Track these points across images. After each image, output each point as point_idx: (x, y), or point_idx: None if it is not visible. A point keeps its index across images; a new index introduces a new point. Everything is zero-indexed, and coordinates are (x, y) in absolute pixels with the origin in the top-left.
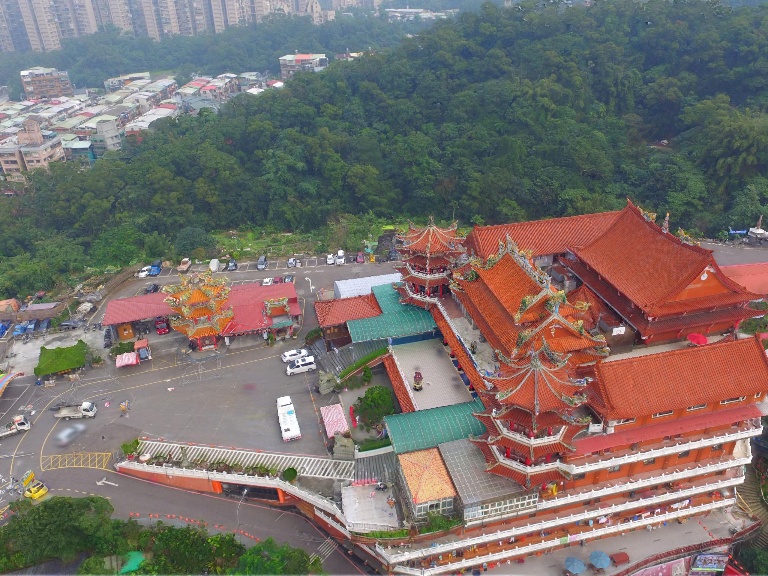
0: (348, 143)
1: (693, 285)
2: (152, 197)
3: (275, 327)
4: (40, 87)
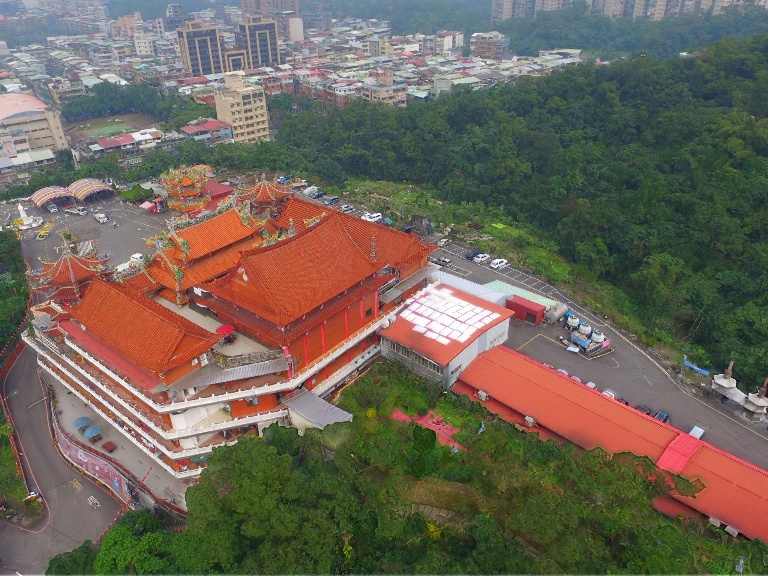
0: (537, 138)
1: (240, 281)
2: (374, 139)
3: None
4: (480, 48)
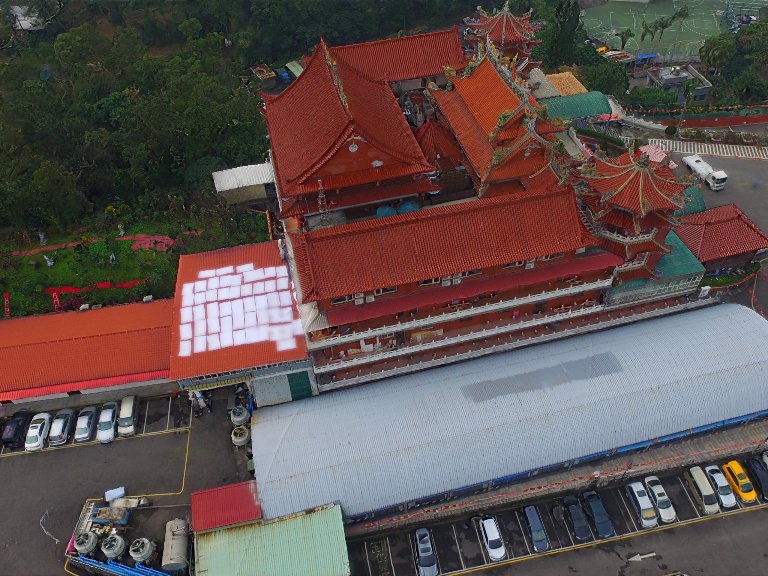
0: None
1: None
2: None
3: None
4: None
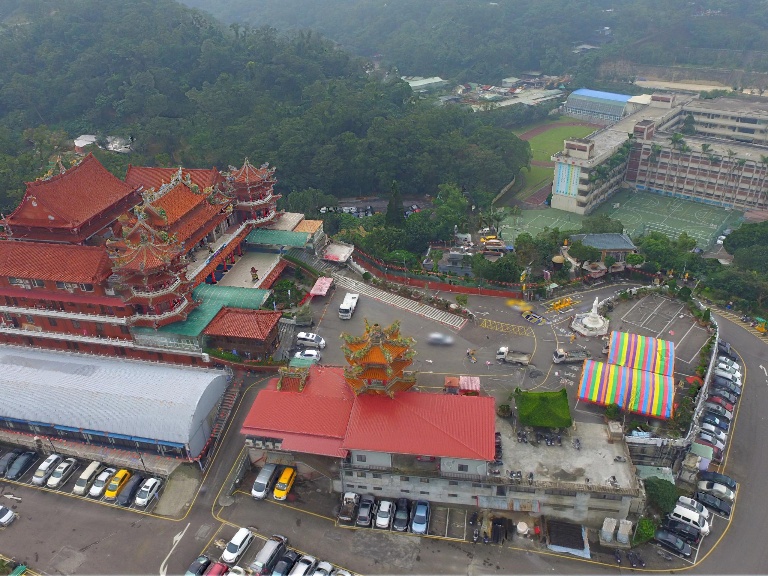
0: None
1: None
2: None
3: (312, 360)
4: None
